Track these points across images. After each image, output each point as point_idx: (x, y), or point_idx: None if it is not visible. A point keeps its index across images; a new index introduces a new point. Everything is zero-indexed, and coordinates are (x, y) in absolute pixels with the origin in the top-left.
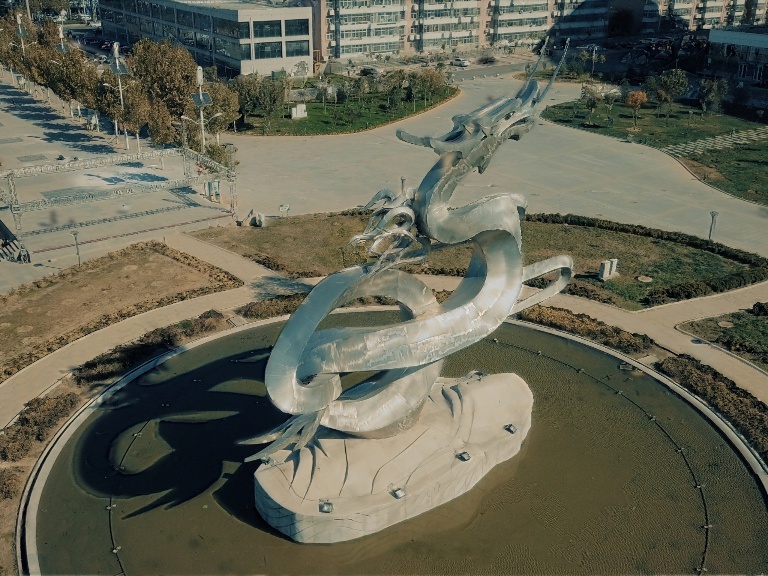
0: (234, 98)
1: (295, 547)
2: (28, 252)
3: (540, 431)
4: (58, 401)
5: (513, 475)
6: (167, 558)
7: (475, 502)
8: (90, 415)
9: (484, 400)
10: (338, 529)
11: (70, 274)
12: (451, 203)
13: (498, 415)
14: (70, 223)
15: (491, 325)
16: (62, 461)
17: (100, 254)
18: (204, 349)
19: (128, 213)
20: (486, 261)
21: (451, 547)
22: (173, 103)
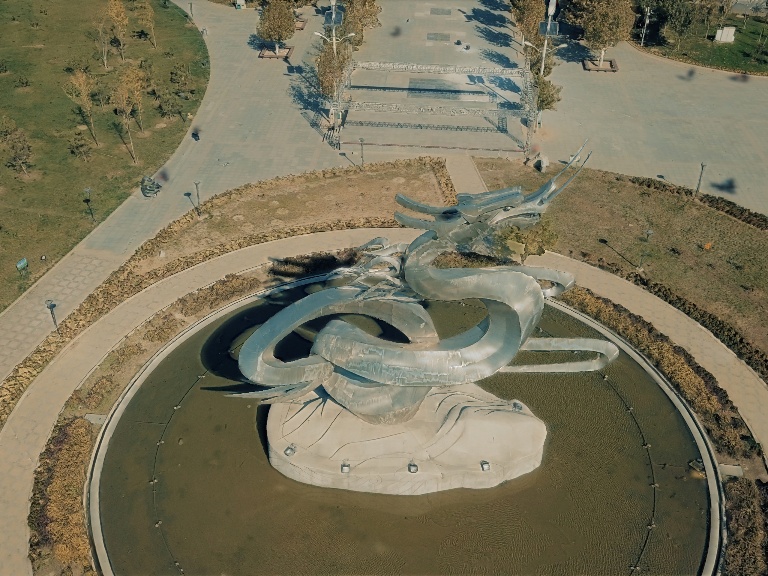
0: (628, 17)
1: (267, 466)
2: (340, 141)
3: (544, 480)
4: (243, 282)
5: (485, 502)
6: (198, 429)
7: (428, 506)
8: (253, 302)
9: (477, 431)
10: (292, 470)
11: (353, 171)
12: (762, 203)
13: (485, 449)
14: (392, 121)
15: (470, 377)
16: (208, 329)
17: (391, 158)
18: (372, 279)
19: (442, 124)
20: (490, 321)
21: (356, 528)
22: (581, 6)
